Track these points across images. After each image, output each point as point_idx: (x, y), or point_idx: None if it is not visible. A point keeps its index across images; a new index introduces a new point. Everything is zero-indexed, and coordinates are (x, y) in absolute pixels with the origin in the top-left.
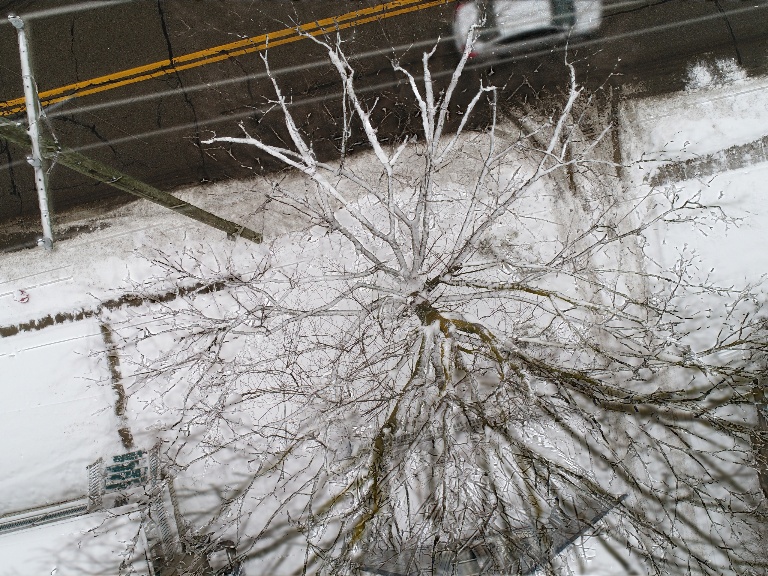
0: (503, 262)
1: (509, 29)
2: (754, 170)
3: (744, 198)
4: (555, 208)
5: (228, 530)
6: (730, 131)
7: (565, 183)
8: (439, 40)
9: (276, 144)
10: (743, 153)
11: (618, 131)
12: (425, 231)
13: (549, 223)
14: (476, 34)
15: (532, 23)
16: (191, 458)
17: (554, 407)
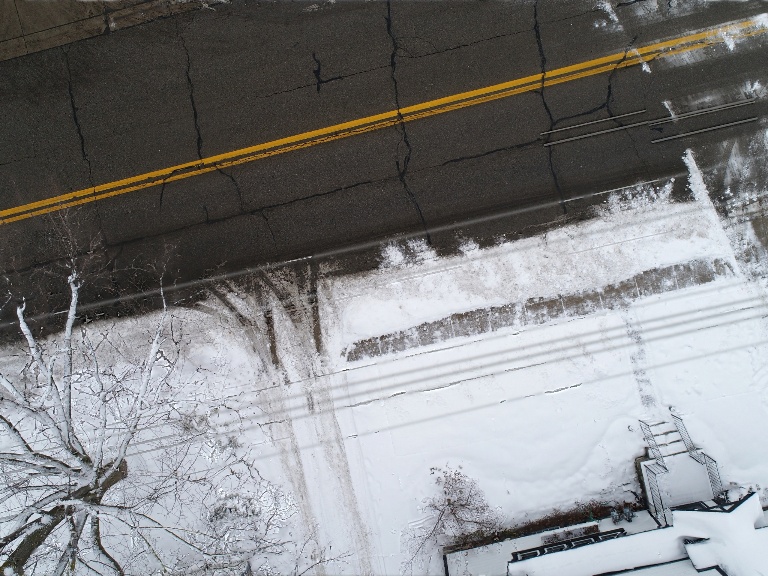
0: (205, 436)
1: (212, 211)
2: None
3: (429, 376)
4: (259, 381)
5: None
6: (416, 311)
7: (268, 357)
8: (24, 300)
9: (1, 318)
10: (433, 330)
11: (318, 307)
12: None
13: (252, 396)
14: (78, 281)
15: (233, 205)
16: None
17: None
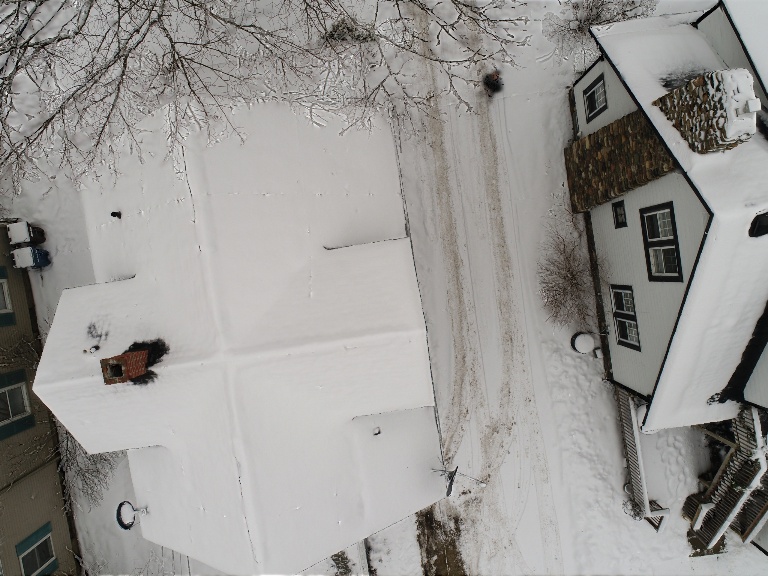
0: None
1: None
2: None
3: None
4: None
5: (38, 215)
6: None
7: None
8: None
9: None
10: None
11: None
12: None
13: None
14: None
15: None
16: (7, 140)
17: None
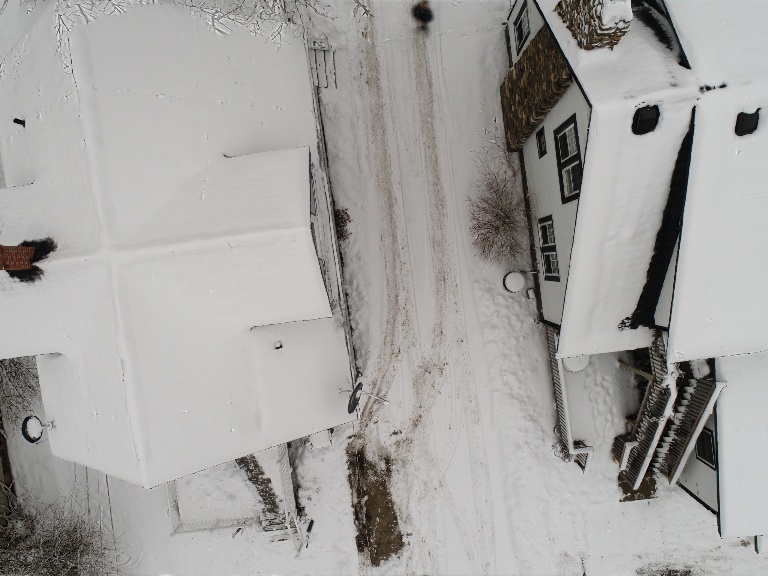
0: None
1: None
2: None
3: None
4: None
5: None
6: None
7: None
8: None
9: None
10: None
11: None
12: None
13: None
14: None
15: None
16: None
17: None
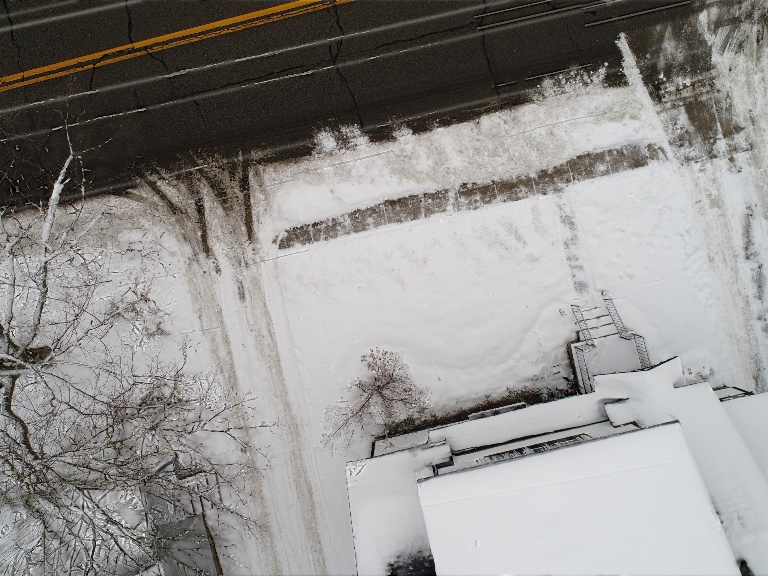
0: None
1: (142, 96)
2: (373, 233)
3: (360, 261)
4: (189, 270)
5: None
6: (348, 196)
7: (199, 245)
8: None
9: None
10: (366, 216)
11: (250, 195)
12: None
13: (182, 285)
14: None
15: (164, 90)
16: None
17: None
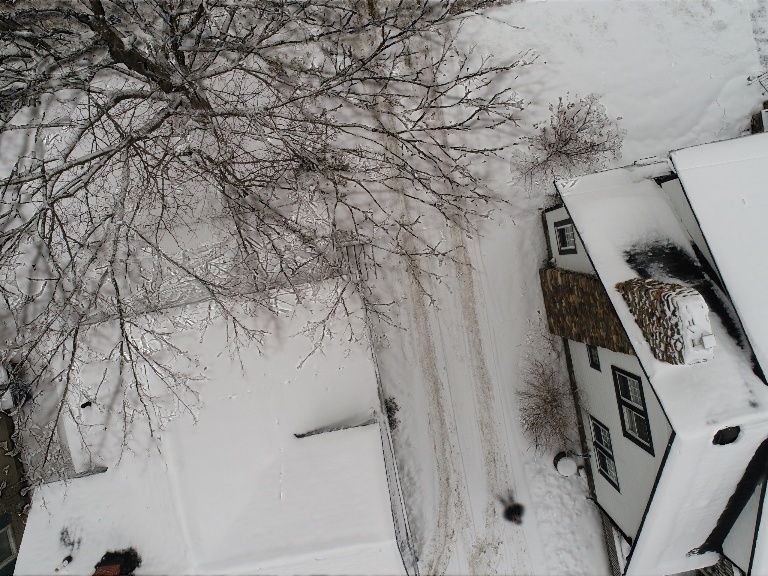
0: None
1: None
2: None
3: (538, 24)
4: None
5: None
6: None
7: (365, 9)
8: None
9: None
10: None
11: None
12: (166, 3)
13: None
14: None
15: None
16: None
17: (260, 161)
